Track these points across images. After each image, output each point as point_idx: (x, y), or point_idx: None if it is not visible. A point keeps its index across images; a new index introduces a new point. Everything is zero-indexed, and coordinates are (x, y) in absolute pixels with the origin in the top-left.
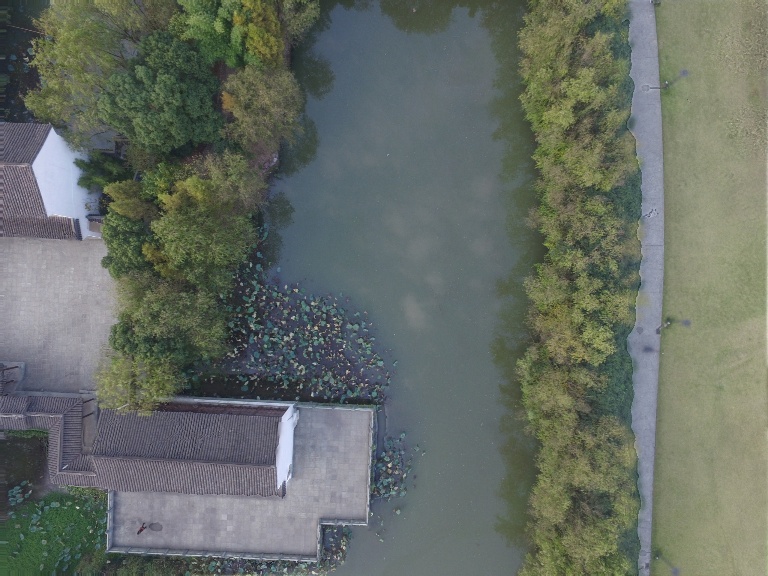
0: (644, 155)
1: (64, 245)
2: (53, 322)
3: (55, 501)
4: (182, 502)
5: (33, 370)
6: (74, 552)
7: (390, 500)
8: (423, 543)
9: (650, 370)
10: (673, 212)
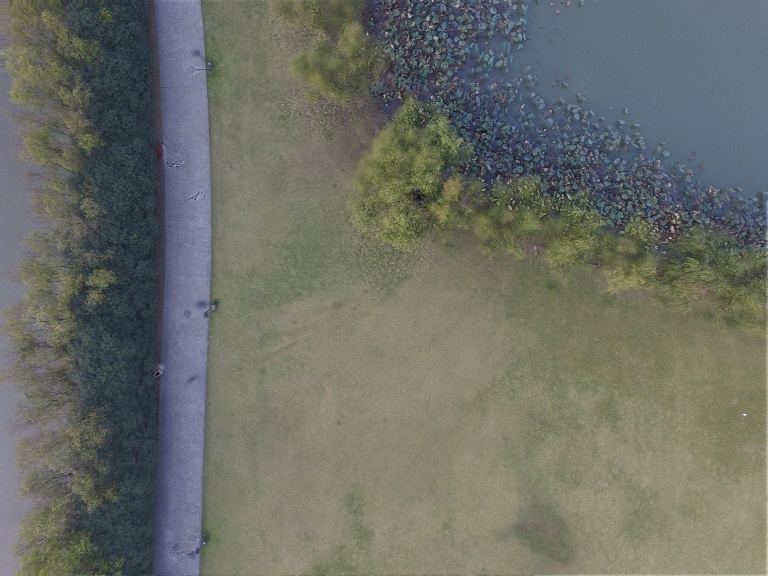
0: (190, 137)
1: None
2: None
3: None
4: None
5: None
6: None
7: None
8: None
9: (199, 354)
10: (219, 194)
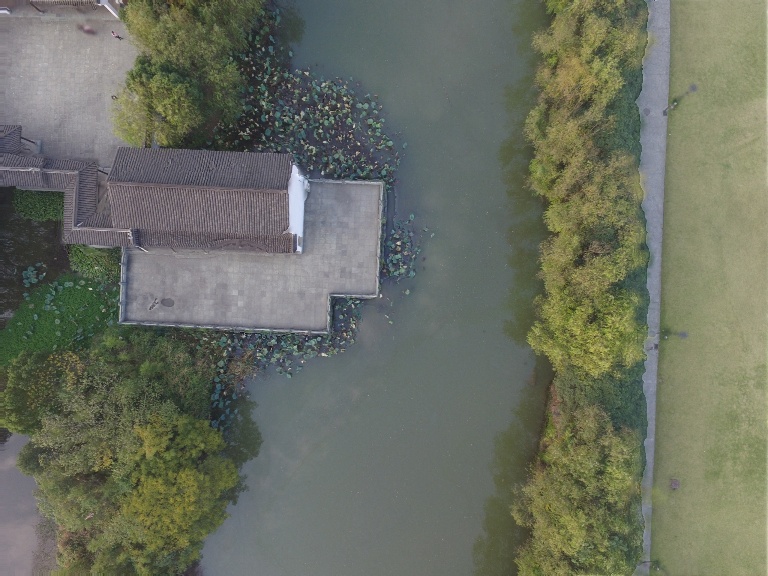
0: None
1: (81, 16)
2: (69, 101)
3: (69, 281)
4: (194, 278)
5: (49, 148)
6: (87, 333)
7: (399, 280)
8: (432, 325)
9: (657, 151)
10: None
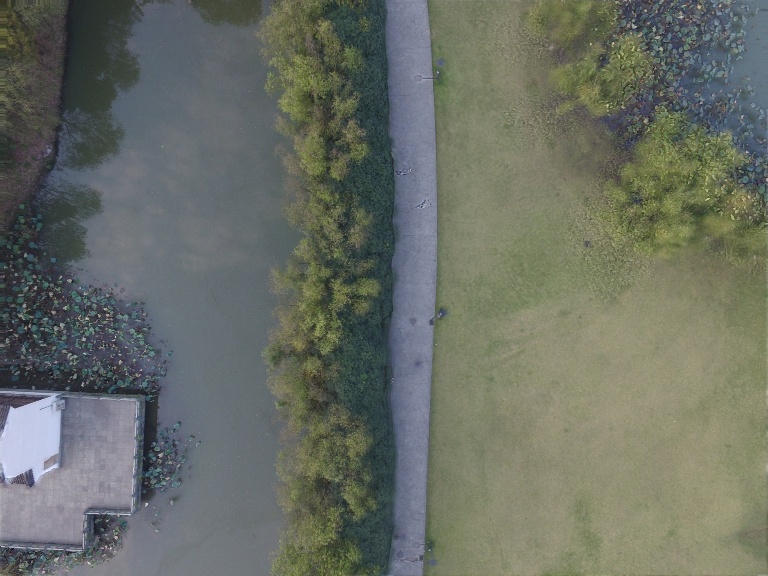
0: (416, 145)
1: None
2: None
3: None
4: None
5: None
6: None
7: (163, 490)
8: (198, 534)
9: (424, 361)
10: (446, 202)
